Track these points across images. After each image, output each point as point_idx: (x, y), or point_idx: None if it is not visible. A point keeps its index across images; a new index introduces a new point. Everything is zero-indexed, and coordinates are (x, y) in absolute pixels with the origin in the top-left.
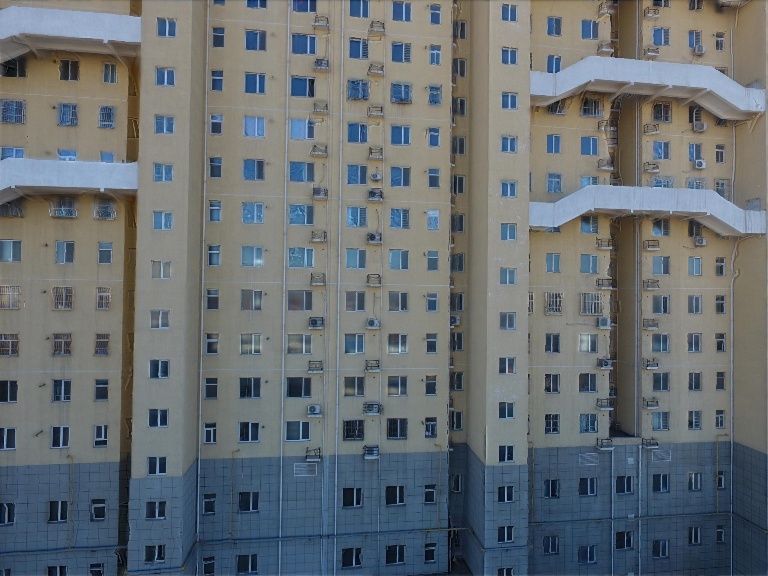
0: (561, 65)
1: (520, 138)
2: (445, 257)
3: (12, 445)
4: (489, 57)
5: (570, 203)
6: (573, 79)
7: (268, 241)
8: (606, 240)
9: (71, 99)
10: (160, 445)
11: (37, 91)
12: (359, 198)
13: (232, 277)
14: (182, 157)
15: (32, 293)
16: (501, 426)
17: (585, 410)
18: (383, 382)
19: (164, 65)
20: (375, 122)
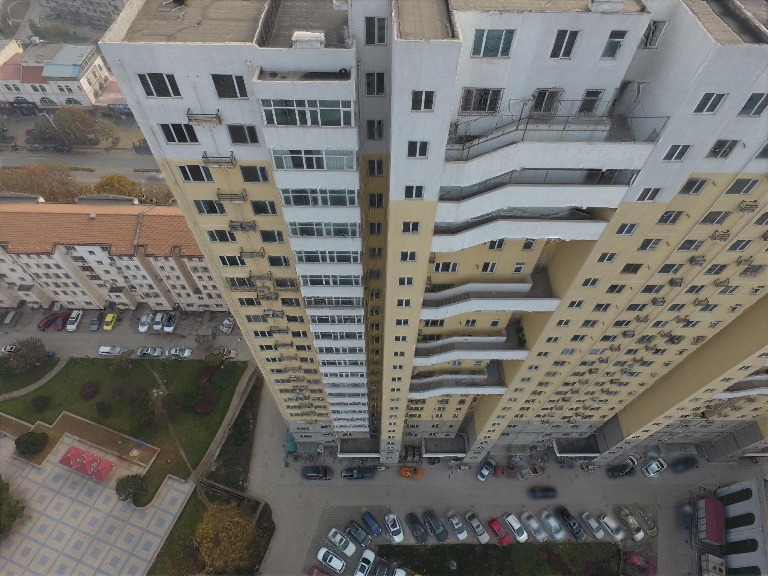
0: None
1: None
2: None
3: None
4: (750, 356)
5: None
6: None
7: None
8: None
9: None
10: None
11: None
12: (615, 370)
13: None
14: (531, 387)
15: None
16: None
17: (686, 414)
18: None
19: (535, 365)
20: None
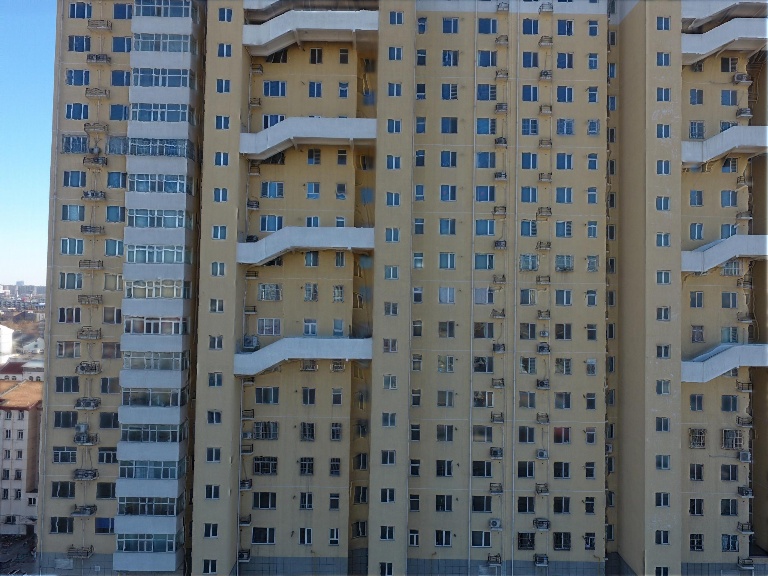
0: (703, 231)
1: (673, 308)
2: (601, 398)
3: (272, 541)
4: (646, 242)
5: (717, 362)
6: (719, 256)
7: (458, 386)
8: (746, 384)
9: (313, 280)
10: (388, 554)
11: (290, 276)
12: (530, 350)
13: (430, 415)
14: (404, 333)
15: (286, 427)
16: (658, 551)
17: (727, 531)
18: (550, 502)
19: (391, 264)
20: (543, 288)
